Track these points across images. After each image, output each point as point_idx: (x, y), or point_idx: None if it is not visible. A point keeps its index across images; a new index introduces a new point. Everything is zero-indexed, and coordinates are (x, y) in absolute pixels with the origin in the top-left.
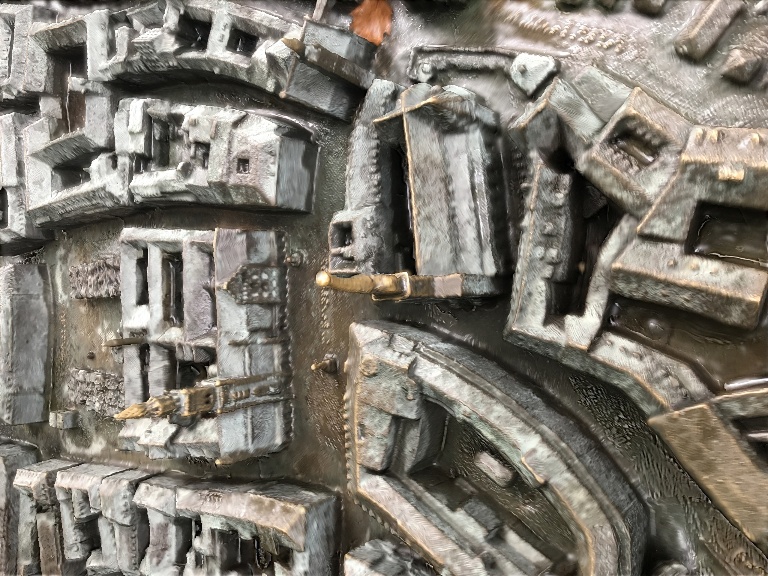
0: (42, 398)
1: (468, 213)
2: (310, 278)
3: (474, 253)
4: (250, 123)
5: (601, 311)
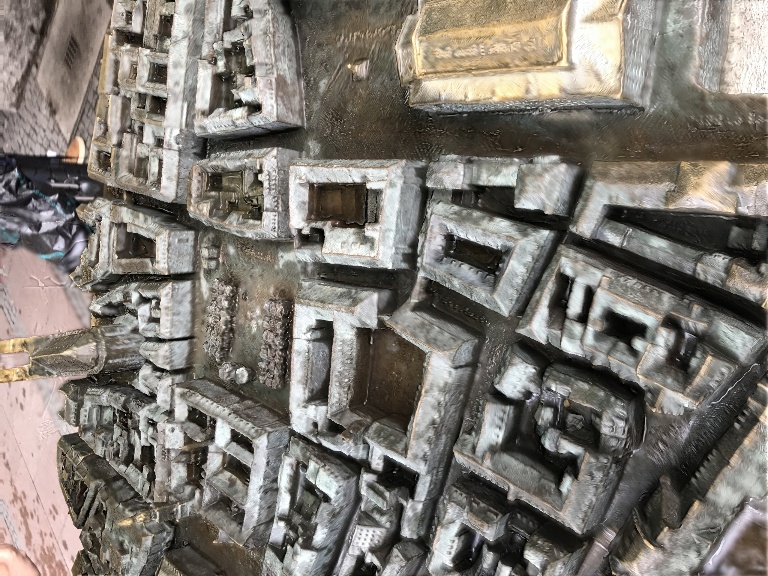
0: None
1: None
2: None
3: None
4: None
5: None
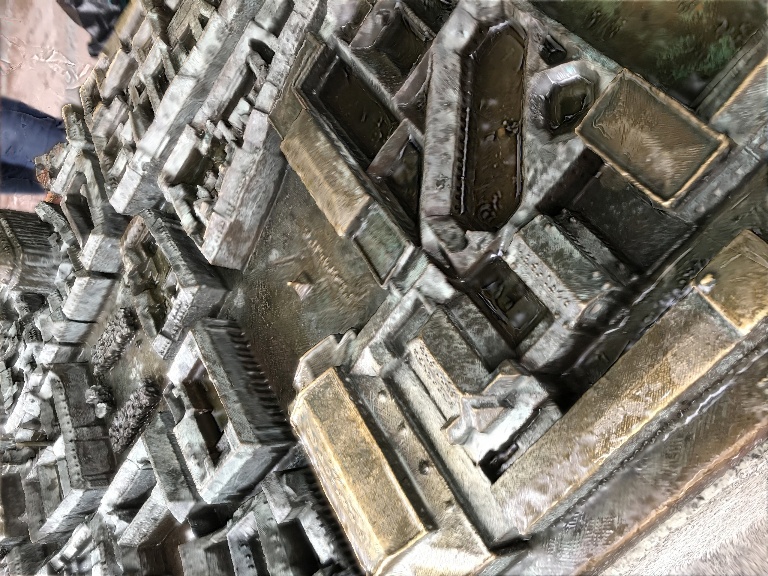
0: None
1: None
2: None
3: None
4: None
5: None
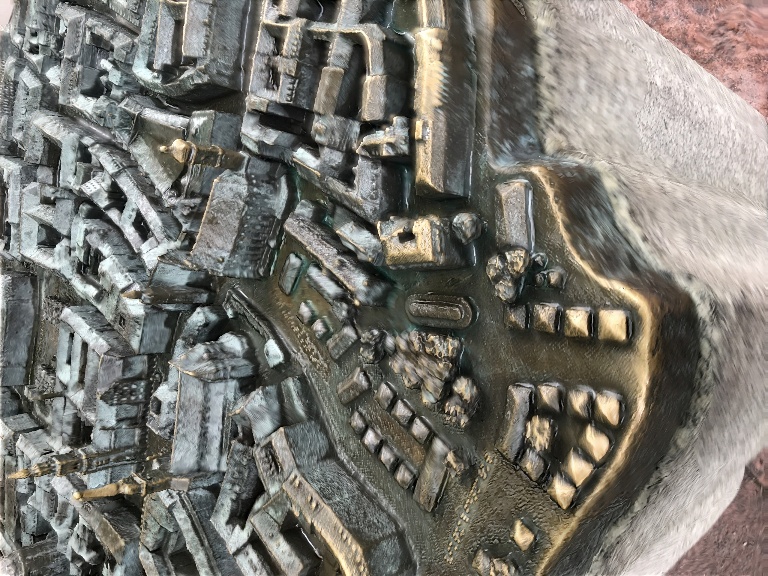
0: (25, 370)
1: (217, 431)
2: None
3: (215, 456)
4: None
5: (250, 533)
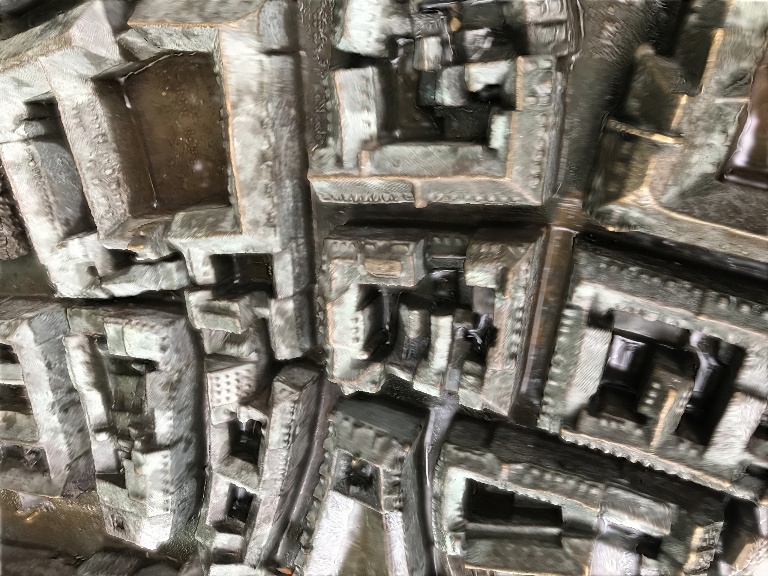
0: None
1: None
2: (95, 493)
3: None
4: (159, 522)
5: None
